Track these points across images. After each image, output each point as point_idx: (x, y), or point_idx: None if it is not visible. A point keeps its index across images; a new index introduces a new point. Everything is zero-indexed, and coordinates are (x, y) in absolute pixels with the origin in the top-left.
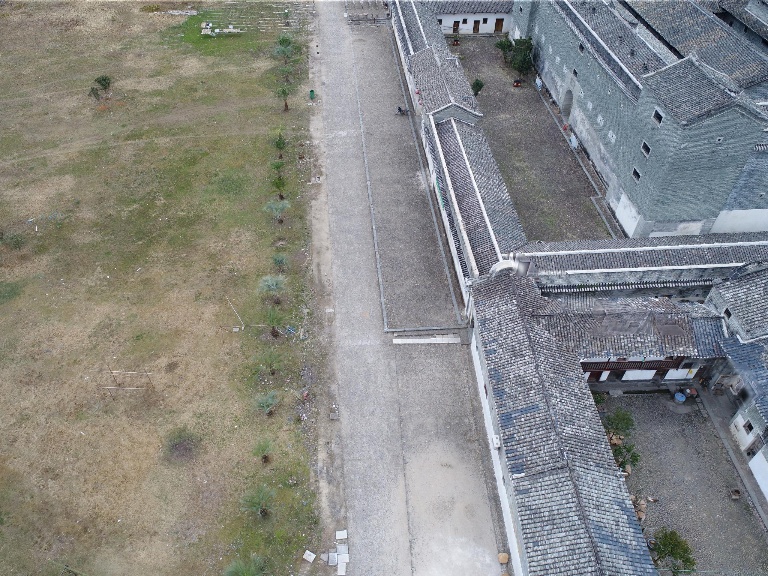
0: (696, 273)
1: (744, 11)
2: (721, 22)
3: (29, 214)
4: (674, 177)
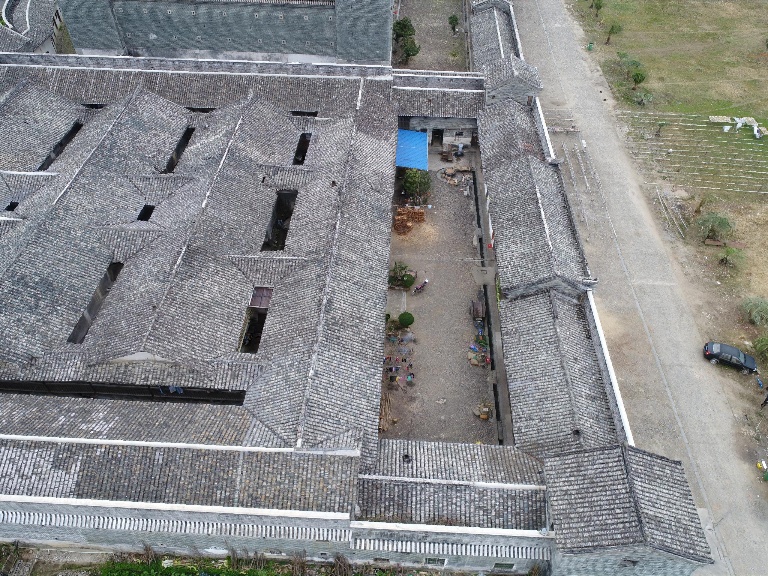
0: None
1: None
2: None
3: (727, 3)
4: None
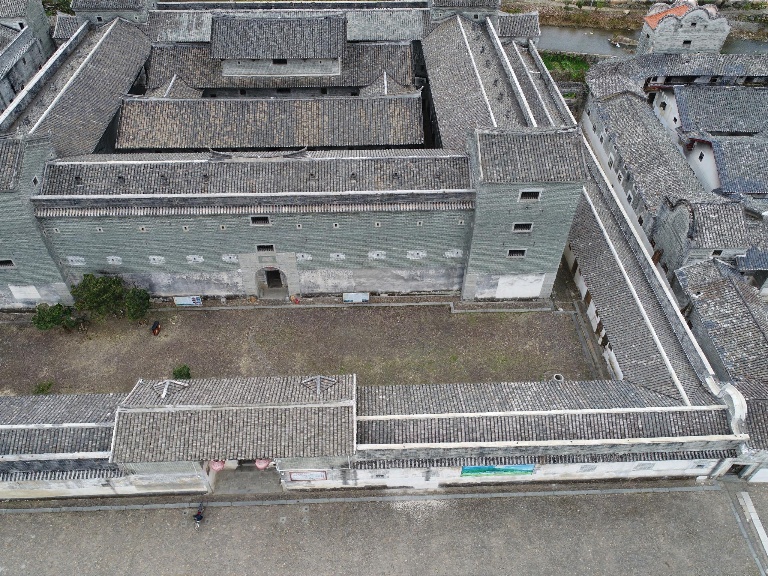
0: None
1: (228, 78)
2: None
3: None
4: None
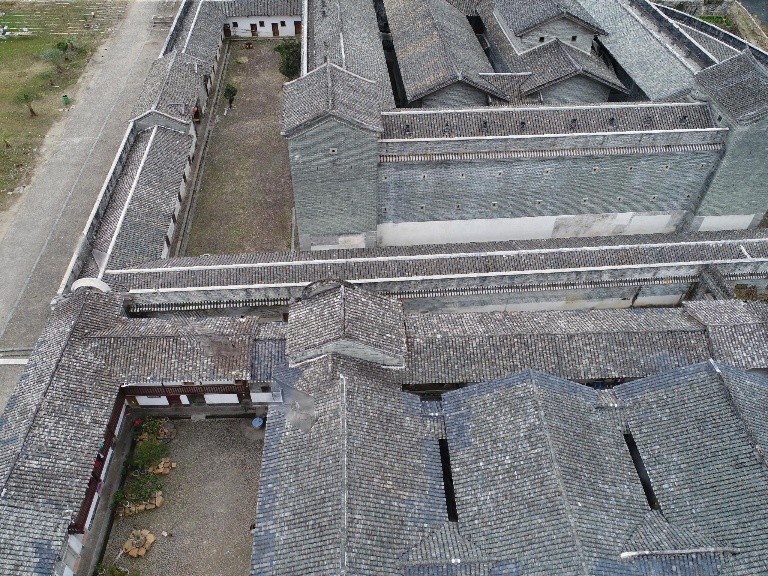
0: None
1: (491, 14)
2: (455, 26)
3: None
4: (305, 189)
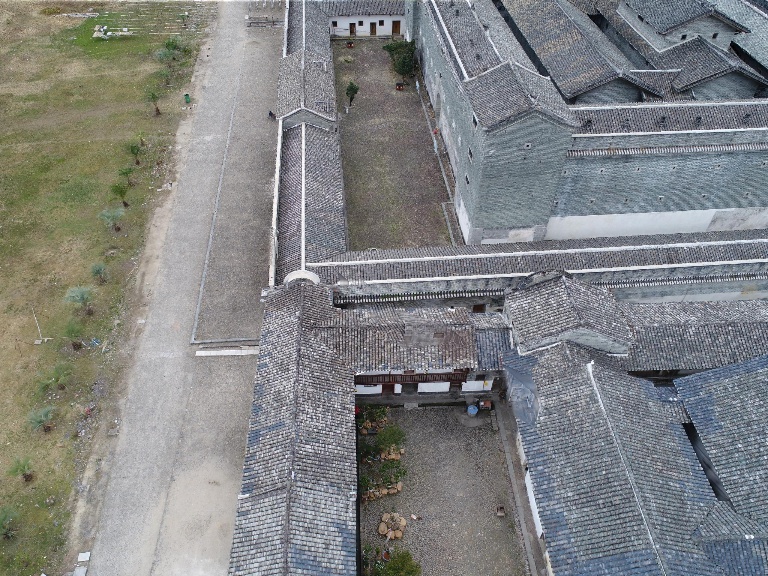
0: (503, 282)
1: (615, 13)
2: (586, 24)
3: None
4: (491, 184)
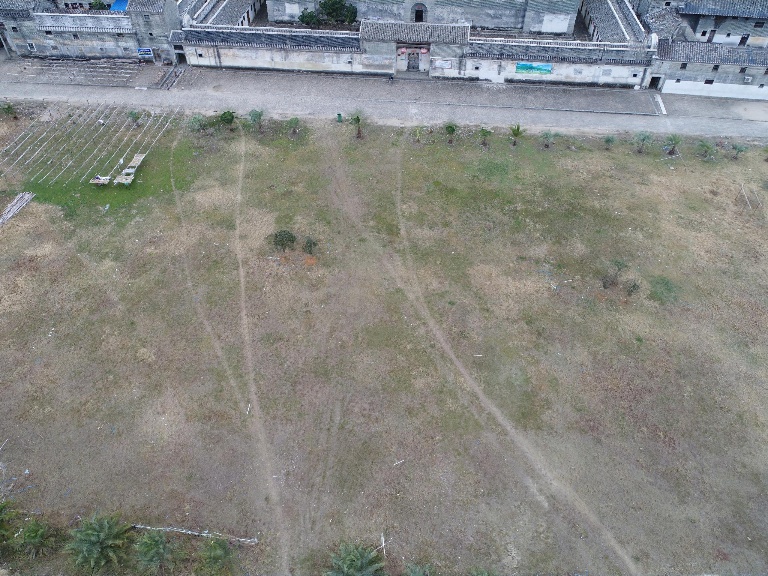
0: None
1: None
2: None
3: (545, 289)
4: None
